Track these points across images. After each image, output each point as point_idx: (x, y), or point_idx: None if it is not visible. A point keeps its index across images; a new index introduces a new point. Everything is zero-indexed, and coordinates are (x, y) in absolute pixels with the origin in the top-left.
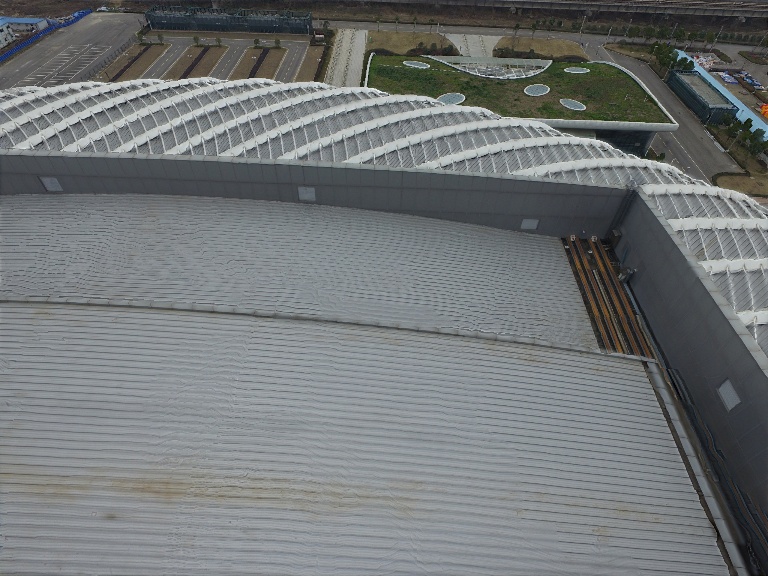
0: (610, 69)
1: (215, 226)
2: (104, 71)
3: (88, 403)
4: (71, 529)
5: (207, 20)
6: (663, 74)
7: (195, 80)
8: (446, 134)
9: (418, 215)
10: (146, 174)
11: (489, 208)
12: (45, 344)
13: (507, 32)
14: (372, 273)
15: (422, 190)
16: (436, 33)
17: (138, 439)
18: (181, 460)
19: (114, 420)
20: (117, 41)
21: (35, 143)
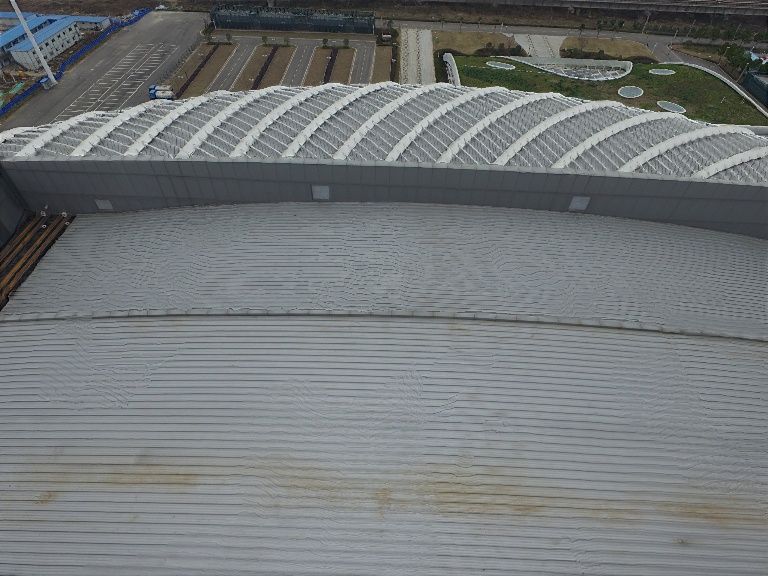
0: (694, 71)
1: (502, 236)
2: (179, 71)
3: (575, 423)
4: (674, 557)
5: (272, 19)
6: (735, 75)
7: (383, 84)
8: (683, 142)
9: (684, 225)
10: (424, 183)
11: (761, 218)
12: (460, 360)
13: (570, 32)
14: (679, 285)
15: (701, 200)
16: (499, 33)
17: (663, 462)
18: (733, 485)
19: (613, 441)
20: (184, 40)
21: (295, 150)
